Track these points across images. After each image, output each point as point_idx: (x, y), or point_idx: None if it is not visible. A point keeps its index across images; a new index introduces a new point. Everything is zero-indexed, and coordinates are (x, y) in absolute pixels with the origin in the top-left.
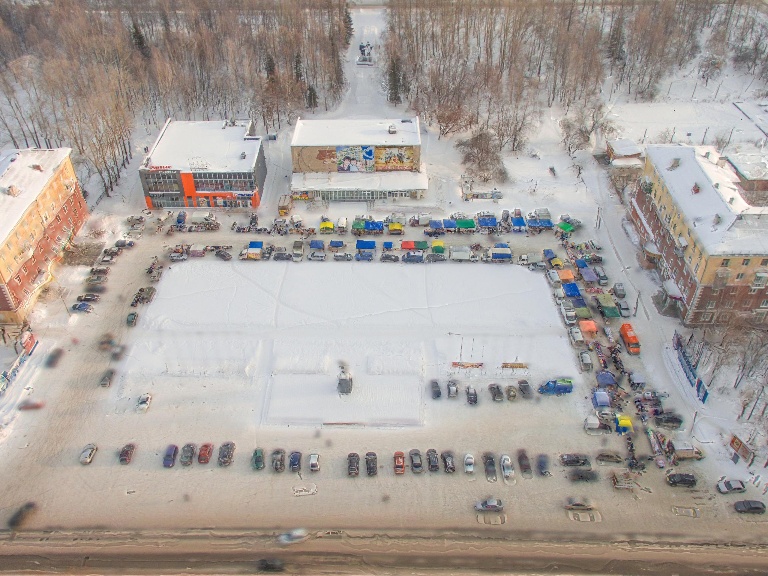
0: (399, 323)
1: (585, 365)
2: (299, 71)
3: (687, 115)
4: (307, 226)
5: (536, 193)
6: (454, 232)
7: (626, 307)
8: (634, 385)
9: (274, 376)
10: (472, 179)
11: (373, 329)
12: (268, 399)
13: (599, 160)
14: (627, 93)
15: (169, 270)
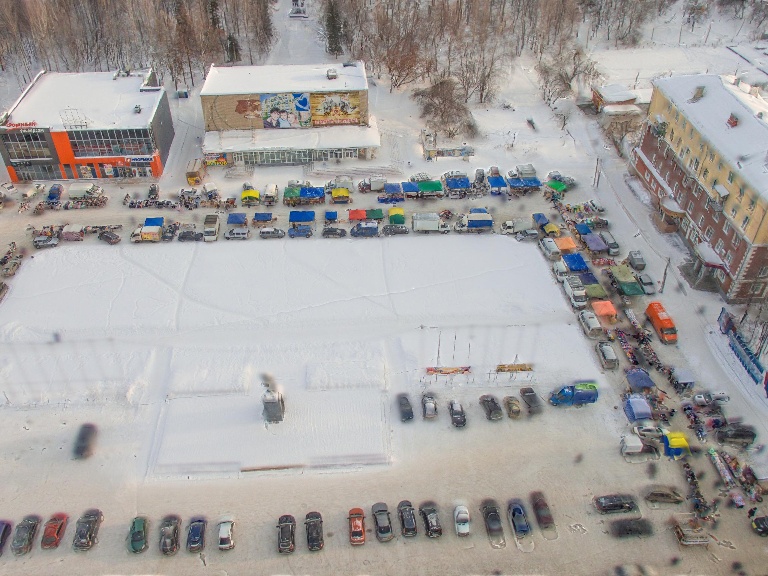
0: (349, 316)
1: (609, 361)
2: (215, 16)
3: (677, 60)
4: (225, 197)
5: (515, 148)
6: (416, 197)
7: (649, 281)
8: (679, 386)
9: (169, 402)
10: (435, 133)
11: (314, 326)
12: (159, 437)
13: (585, 110)
14: (606, 39)
15: (30, 260)
